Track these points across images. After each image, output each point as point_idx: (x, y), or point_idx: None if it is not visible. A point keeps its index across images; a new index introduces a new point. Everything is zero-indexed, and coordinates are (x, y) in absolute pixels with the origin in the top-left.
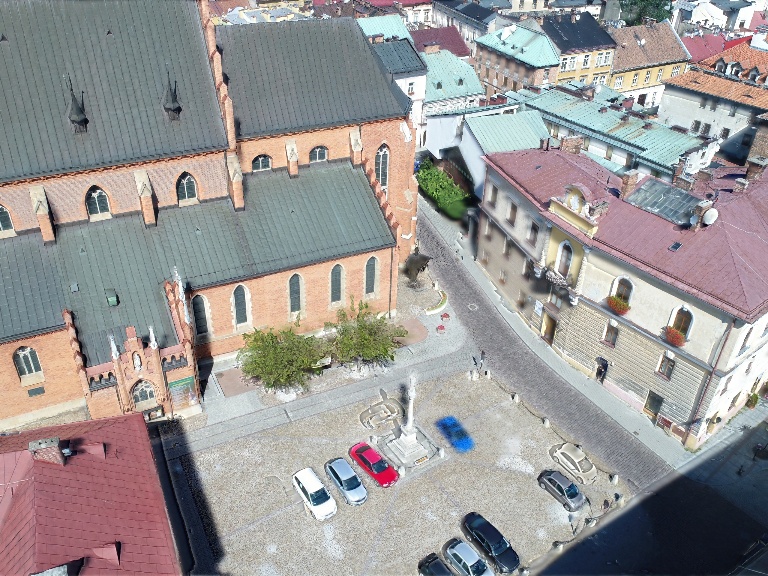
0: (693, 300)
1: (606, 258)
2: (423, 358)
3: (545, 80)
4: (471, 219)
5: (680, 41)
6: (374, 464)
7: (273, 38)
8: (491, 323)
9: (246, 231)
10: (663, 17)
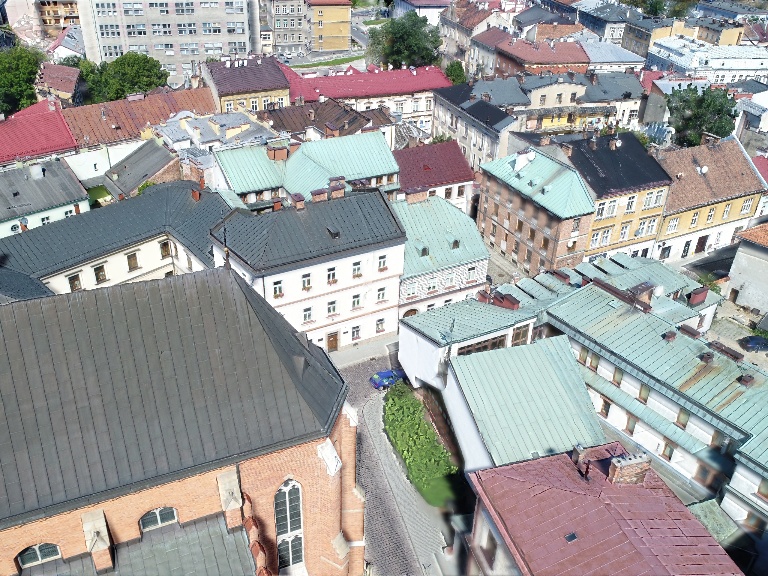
0: None
1: None
2: None
3: (574, 232)
4: (456, 532)
5: (752, 165)
6: None
7: (59, 325)
8: None
9: None
10: (726, 127)
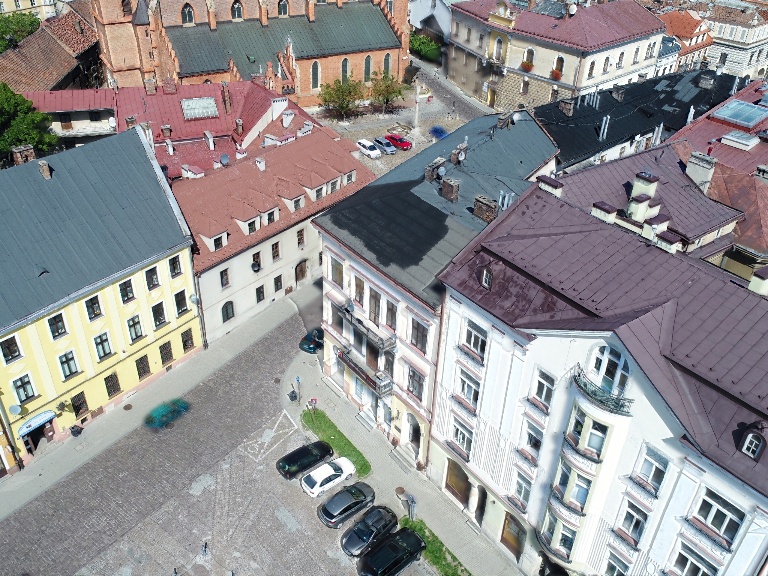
0: (563, 49)
1: (520, 39)
2: (419, 112)
3: None
4: (443, 54)
5: None
6: (399, 139)
7: None
8: (458, 101)
9: (317, 33)
10: None
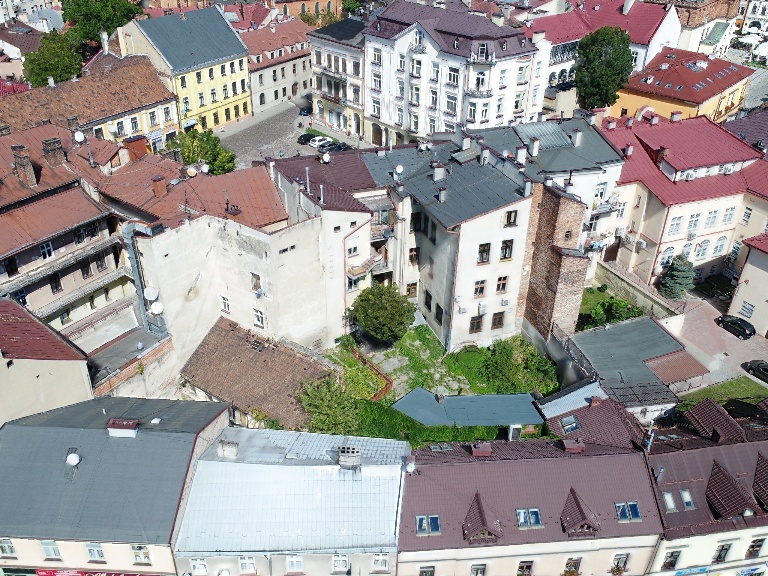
0: None
1: None
2: None
3: None
4: None
5: None
6: None
7: None
8: None
9: None
10: None
